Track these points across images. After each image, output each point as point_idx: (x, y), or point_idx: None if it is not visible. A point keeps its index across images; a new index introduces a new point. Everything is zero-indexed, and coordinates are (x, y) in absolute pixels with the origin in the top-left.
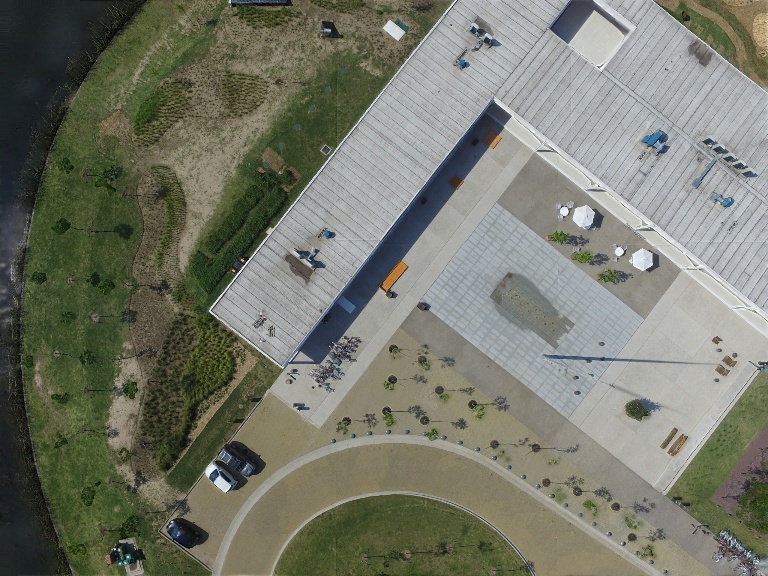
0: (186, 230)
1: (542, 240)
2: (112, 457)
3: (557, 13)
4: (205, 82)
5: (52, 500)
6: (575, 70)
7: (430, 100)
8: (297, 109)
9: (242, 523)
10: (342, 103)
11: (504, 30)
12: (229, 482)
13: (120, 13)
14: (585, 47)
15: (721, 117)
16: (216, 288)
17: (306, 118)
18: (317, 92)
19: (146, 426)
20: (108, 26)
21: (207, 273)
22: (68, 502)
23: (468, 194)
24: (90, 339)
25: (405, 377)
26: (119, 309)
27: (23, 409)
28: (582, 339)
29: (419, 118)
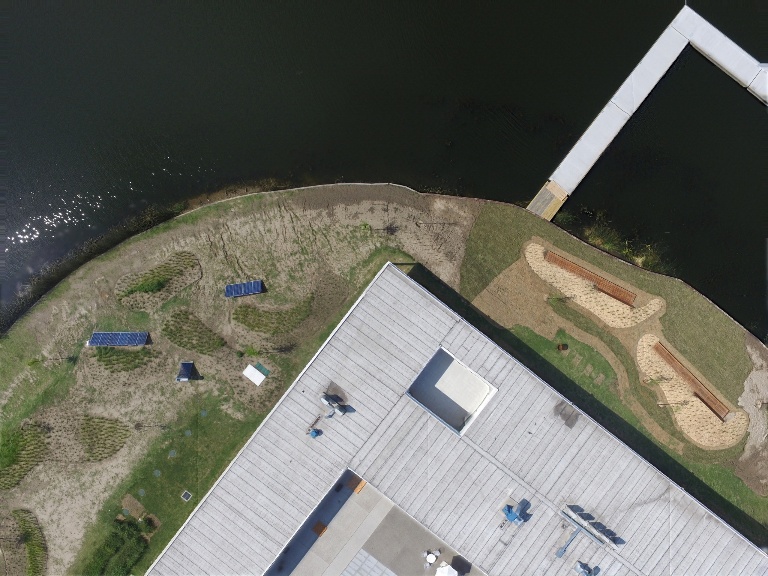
0: (47, 575)
1: None
2: None
3: (414, 377)
4: (64, 427)
5: None
6: (433, 436)
7: (281, 470)
8: (157, 454)
9: None
10: (202, 448)
11: (359, 395)
12: None
13: None
14: (454, 386)
15: (587, 482)
16: None
17: (166, 463)
18: (177, 436)
19: None
20: None
21: None
22: None
23: (332, 540)
24: None
25: None
26: None
27: None
28: None
29: (270, 490)
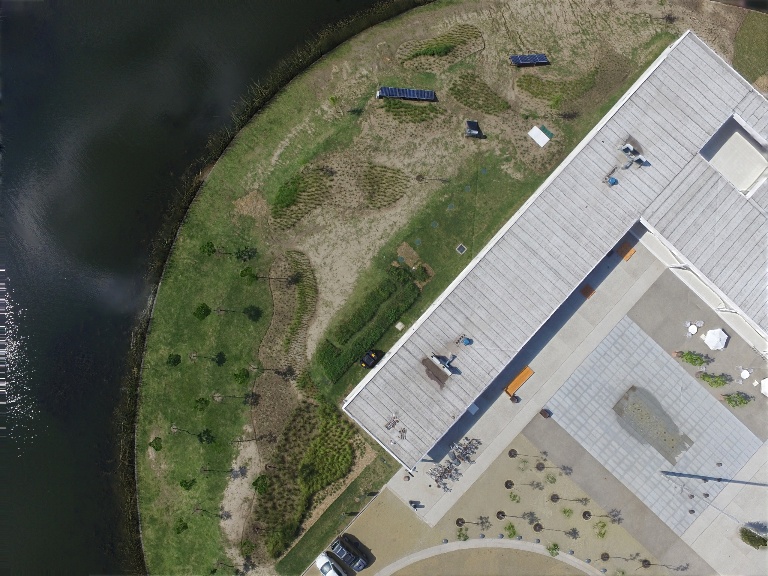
0: (316, 317)
1: (668, 356)
2: (223, 539)
3: (708, 138)
4: (347, 172)
5: (155, 574)
6: (722, 196)
7: (577, 215)
8: (436, 206)
9: None
10: (481, 204)
11: (655, 151)
12: None
13: (261, 91)
14: (724, 167)
15: None
16: (342, 378)
17: (444, 216)
18: (457, 190)
19: (260, 511)
20: (248, 103)
21: (335, 363)
22: None
23: (599, 304)
24: (211, 418)
25: (522, 482)
26: (242, 391)
27: (133, 480)
28: (700, 458)
29: (565, 232)
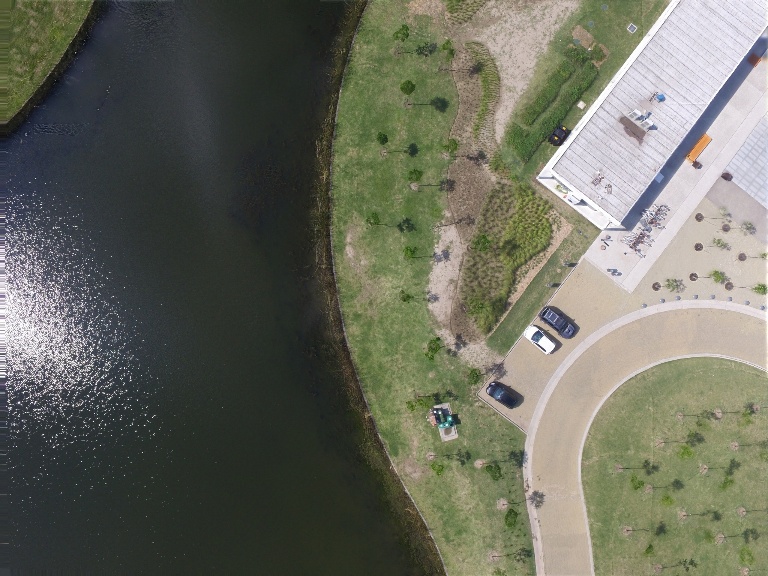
0: (501, 103)
1: None
2: (432, 321)
3: None
4: None
5: (363, 369)
6: None
7: None
8: None
9: (557, 386)
10: None
11: None
12: (553, 342)
13: None
14: None
15: None
16: (532, 158)
17: None
18: None
19: (467, 290)
20: None
21: (525, 143)
22: (380, 370)
23: (765, 72)
24: (409, 207)
25: (710, 244)
26: (437, 178)
27: (333, 280)
28: None
29: None
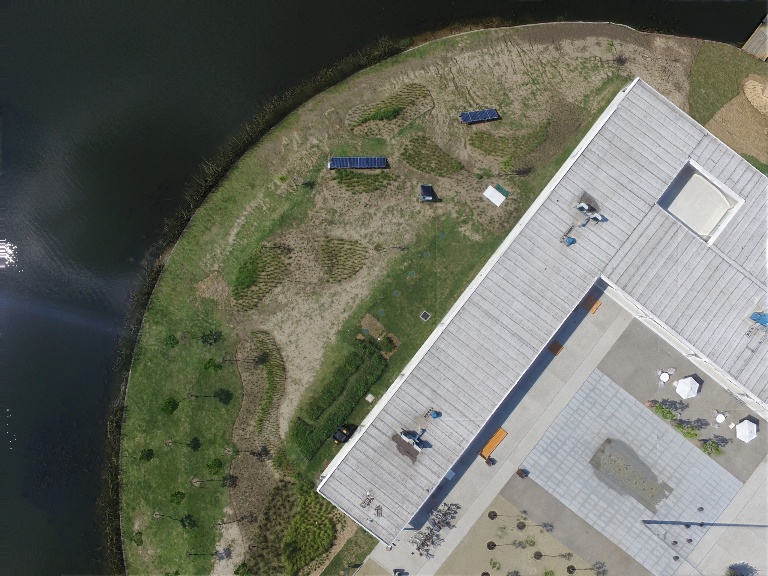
0: (286, 396)
1: (642, 405)
2: None
3: (665, 187)
4: (304, 248)
5: None
6: (683, 245)
7: (537, 278)
8: (396, 275)
9: None
10: (441, 268)
11: (611, 205)
12: None
13: (214, 169)
14: (686, 209)
15: None
16: (316, 455)
17: (405, 284)
18: (416, 257)
19: None
20: (202, 182)
21: (308, 441)
22: None
23: (568, 360)
24: (191, 504)
25: (504, 543)
26: (220, 474)
27: (122, 566)
28: (681, 504)
29: (526, 296)
